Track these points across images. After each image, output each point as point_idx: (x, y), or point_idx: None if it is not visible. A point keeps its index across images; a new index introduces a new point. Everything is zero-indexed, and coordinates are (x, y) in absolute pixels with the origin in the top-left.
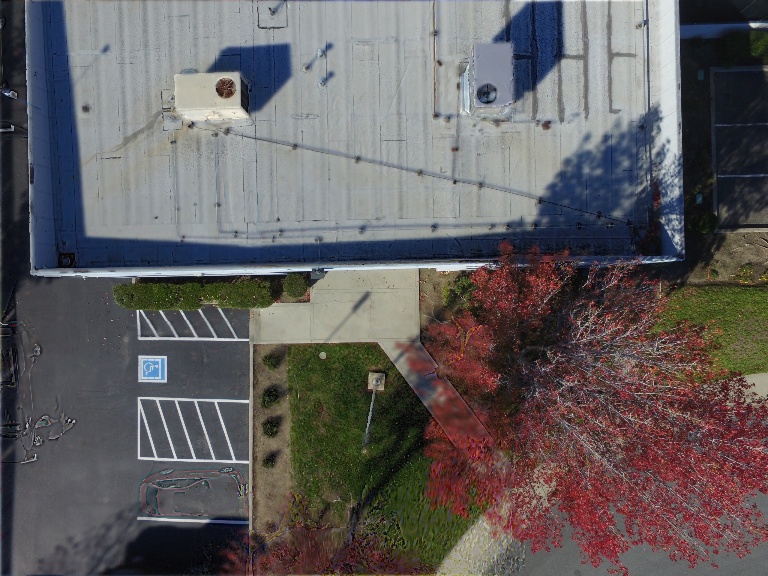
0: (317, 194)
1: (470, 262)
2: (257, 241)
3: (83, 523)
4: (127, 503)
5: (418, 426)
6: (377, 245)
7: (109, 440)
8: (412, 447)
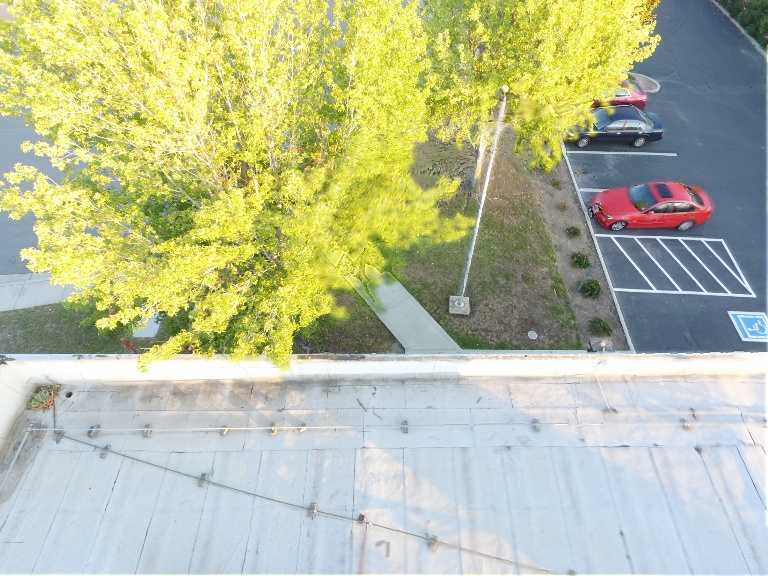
0: (638, 500)
1: (346, 358)
2: (722, 410)
3: (753, 191)
4: (715, 205)
5: (407, 262)
6: (502, 402)
7: (767, 257)
8: (414, 243)
